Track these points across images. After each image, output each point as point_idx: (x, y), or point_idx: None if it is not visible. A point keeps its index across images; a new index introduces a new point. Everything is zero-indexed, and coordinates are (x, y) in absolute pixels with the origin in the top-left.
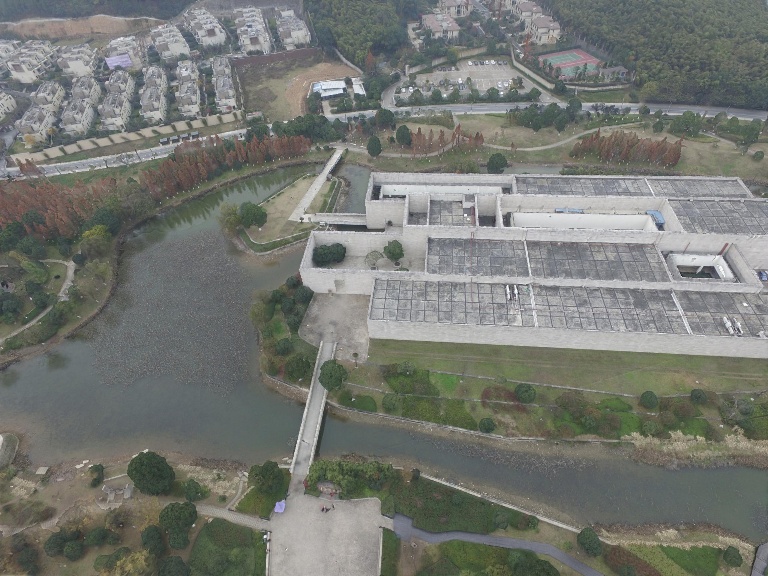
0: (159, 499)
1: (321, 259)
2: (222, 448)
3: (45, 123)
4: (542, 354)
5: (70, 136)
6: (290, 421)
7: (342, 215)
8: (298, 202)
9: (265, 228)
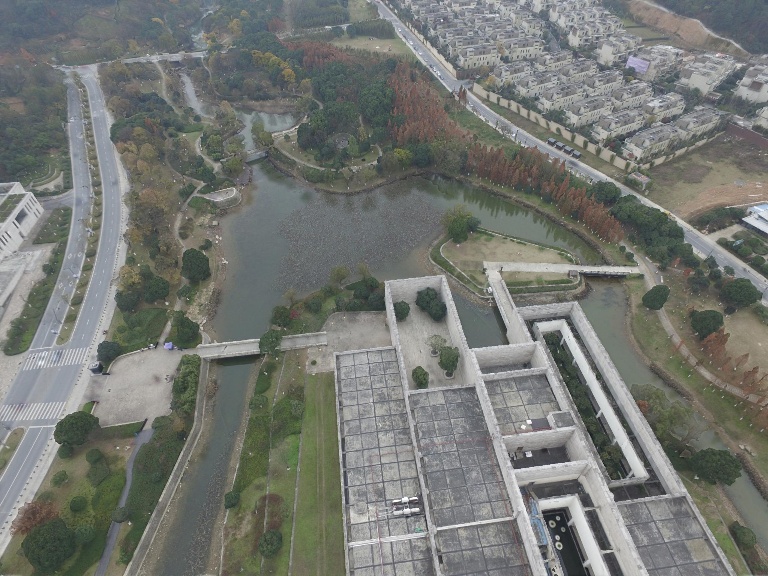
0: (187, 280)
1: (419, 298)
2: (227, 301)
3: (517, 76)
4: (337, 570)
5: (513, 94)
6: (253, 337)
7: (511, 303)
8: (516, 261)
9: (462, 248)
